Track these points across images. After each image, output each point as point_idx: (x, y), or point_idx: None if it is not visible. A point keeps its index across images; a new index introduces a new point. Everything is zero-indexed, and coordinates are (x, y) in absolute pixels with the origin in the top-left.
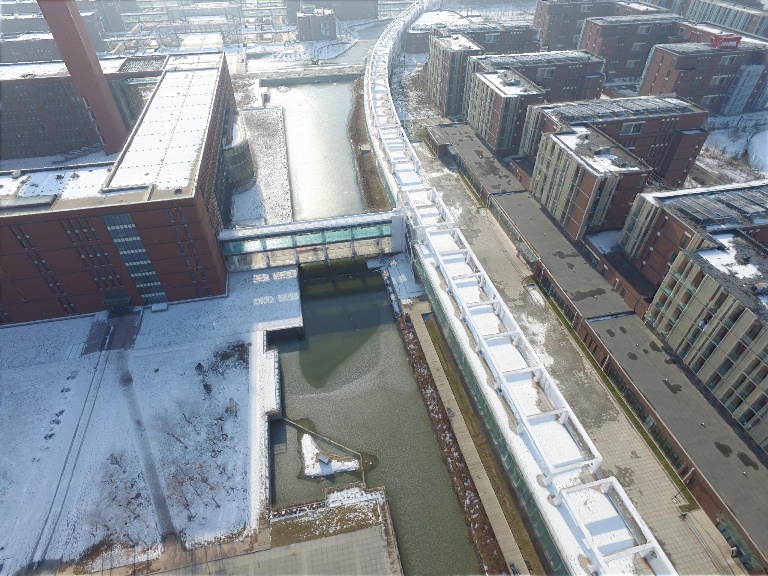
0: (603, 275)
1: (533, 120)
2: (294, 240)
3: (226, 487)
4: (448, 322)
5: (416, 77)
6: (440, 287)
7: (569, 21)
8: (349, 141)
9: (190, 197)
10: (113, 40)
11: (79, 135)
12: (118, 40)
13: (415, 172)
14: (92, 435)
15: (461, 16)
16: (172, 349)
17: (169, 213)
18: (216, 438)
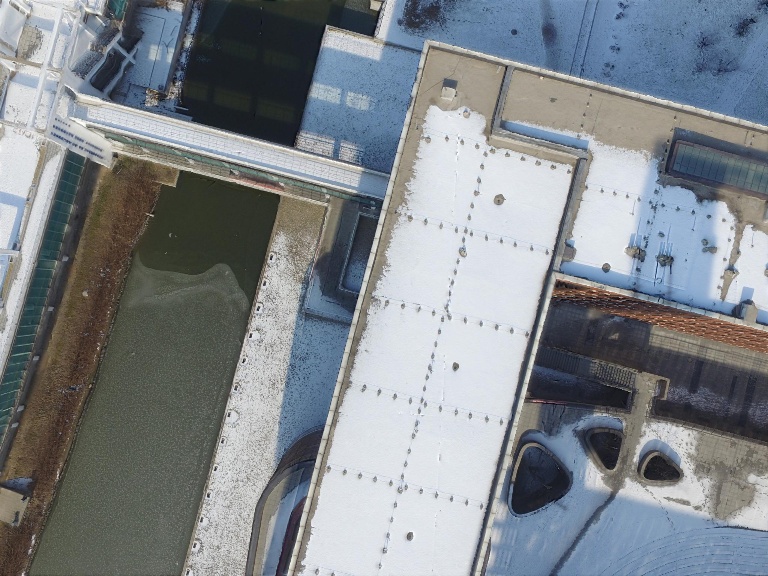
0: None
1: None
2: None
3: None
4: None
5: None
6: None
7: None
8: None
9: None
10: None
11: None
12: None
13: None
14: None
15: None
16: None
17: None
18: None
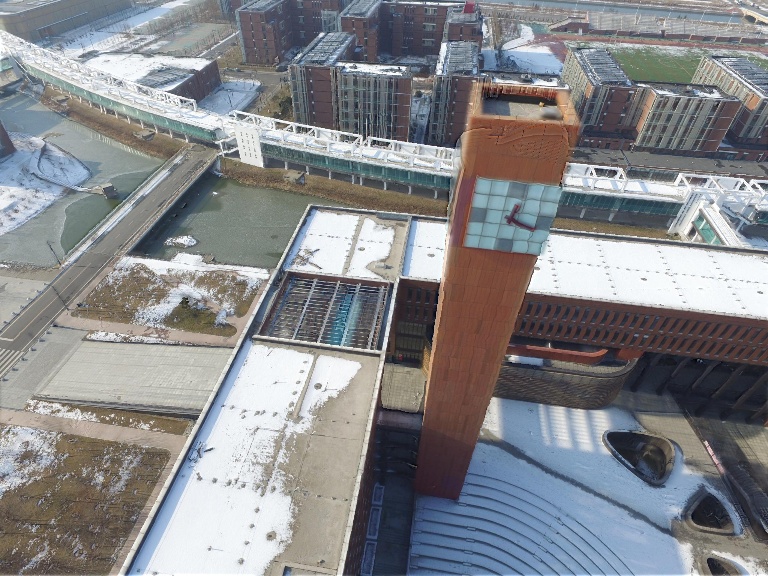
0: (744, 159)
1: (603, 96)
2: None
3: None
4: None
5: None
6: None
7: None
8: None
9: None
10: None
11: None
12: None
13: None
14: None
15: (141, 54)
16: None
17: None
18: None
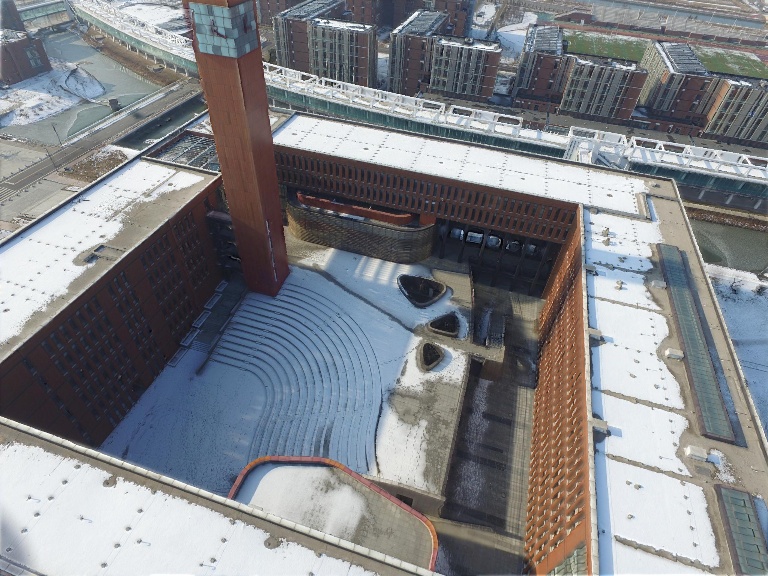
0: (656, 130)
1: (532, 61)
2: None
3: None
4: (717, 177)
5: None
6: (683, 167)
7: None
8: None
9: None
10: None
11: (188, 307)
12: None
13: None
14: None
15: (170, 6)
16: None
17: None
18: None
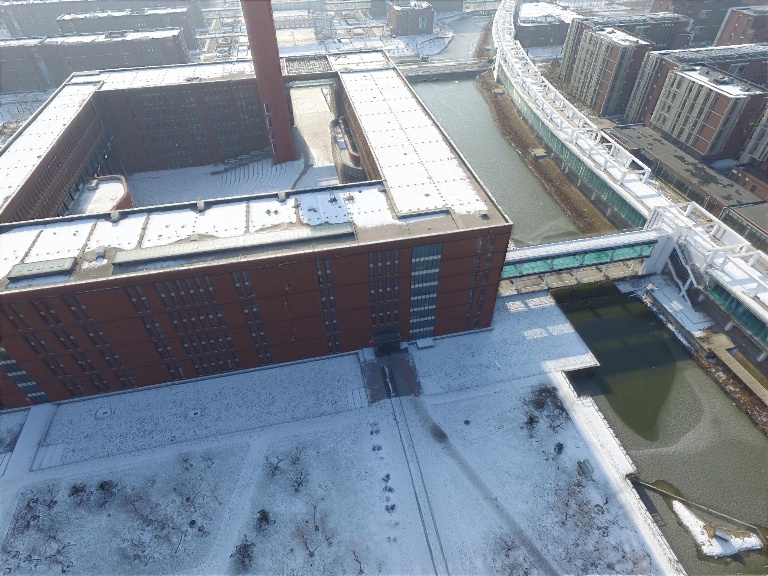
0: None
1: None
2: (552, 264)
3: (639, 575)
4: None
5: (543, 73)
6: None
7: (692, 11)
8: (511, 145)
9: (509, 224)
10: (205, 37)
11: (237, 143)
12: (210, 37)
13: (643, 182)
14: (439, 506)
15: (563, 7)
16: (469, 395)
17: (479, 242)
18: (591, 510)
